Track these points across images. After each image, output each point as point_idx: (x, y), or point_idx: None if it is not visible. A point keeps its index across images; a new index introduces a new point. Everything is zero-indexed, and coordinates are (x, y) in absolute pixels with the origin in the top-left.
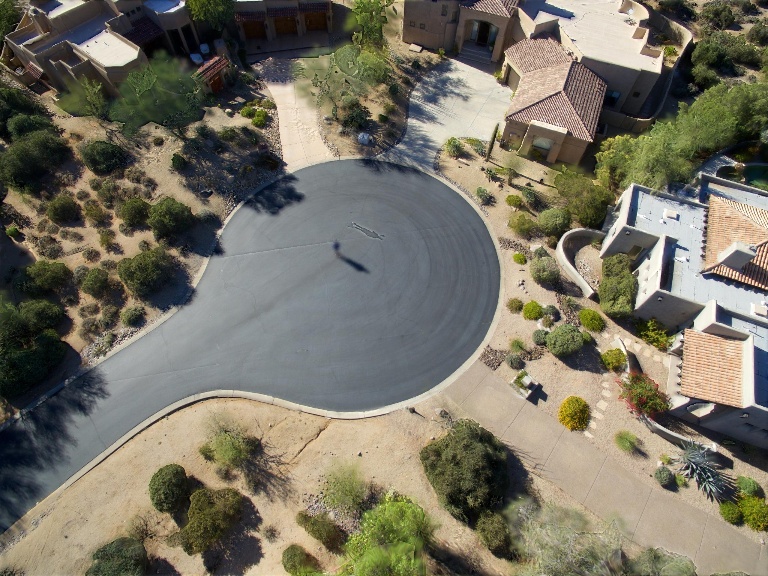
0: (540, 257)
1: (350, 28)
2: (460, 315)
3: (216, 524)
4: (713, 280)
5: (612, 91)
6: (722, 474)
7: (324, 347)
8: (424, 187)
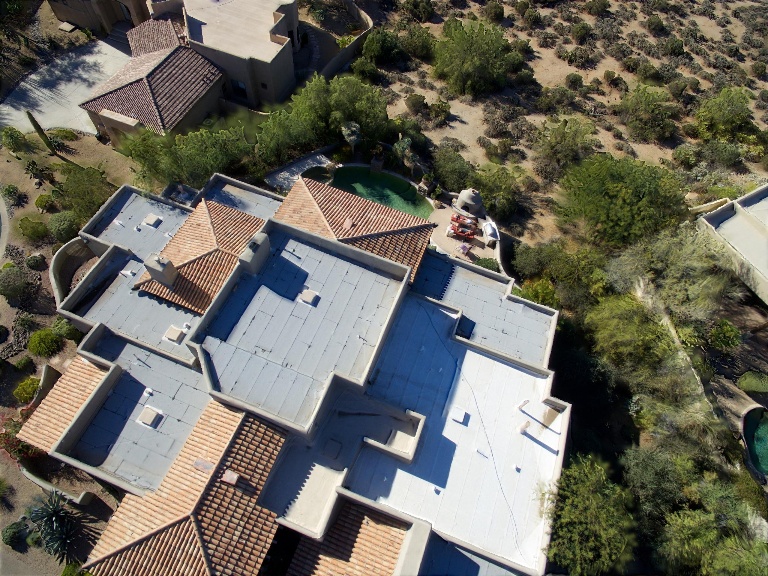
0: (30, 267)
1: (1, 2)
2: None
3: None
4: (147, 298)
5: (236, 81)
6: (91, 529)
7: None
8: None
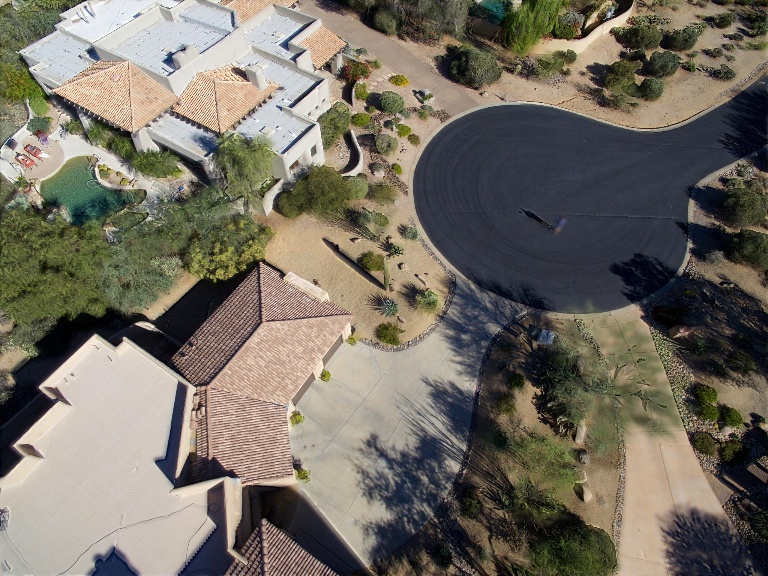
0: None
1: None
2: (460, 143)
3: (618, 64)
4: None
5: None
6: None
7: (567, 139)
8: (473, 259)
